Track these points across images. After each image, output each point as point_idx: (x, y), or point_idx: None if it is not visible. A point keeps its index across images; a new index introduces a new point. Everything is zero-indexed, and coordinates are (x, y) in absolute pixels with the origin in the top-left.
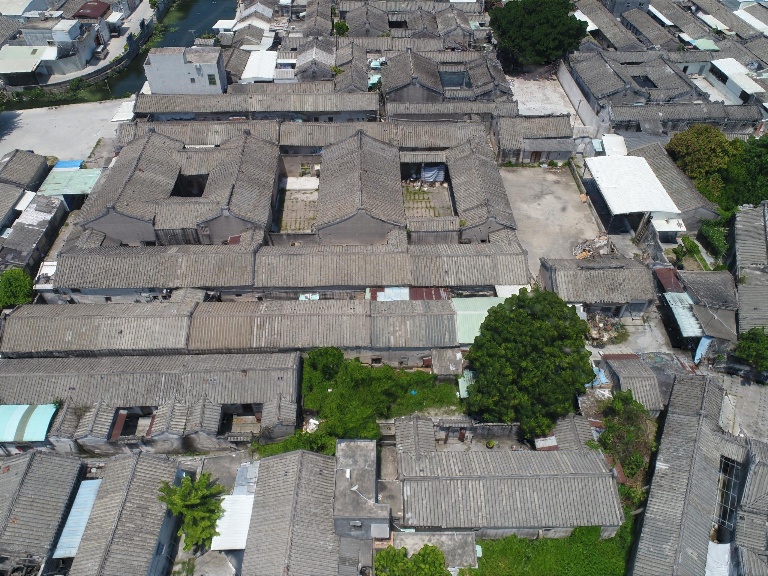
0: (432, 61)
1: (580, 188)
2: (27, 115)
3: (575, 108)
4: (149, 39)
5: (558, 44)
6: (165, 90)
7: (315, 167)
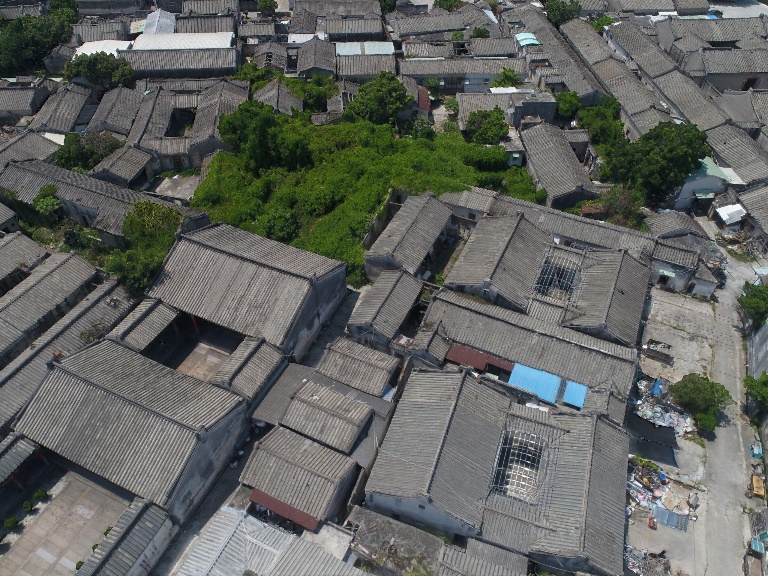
0: None
1: None
2: (760, 6)
3: None
4: None
5: None
6: None
7: None
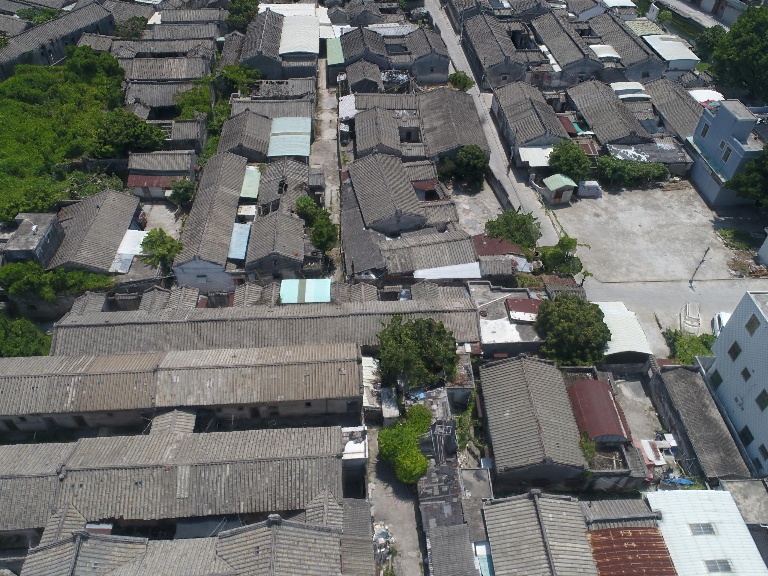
0: None
1: None
2: None
3: None
4: None
5: None
6: None
7: None
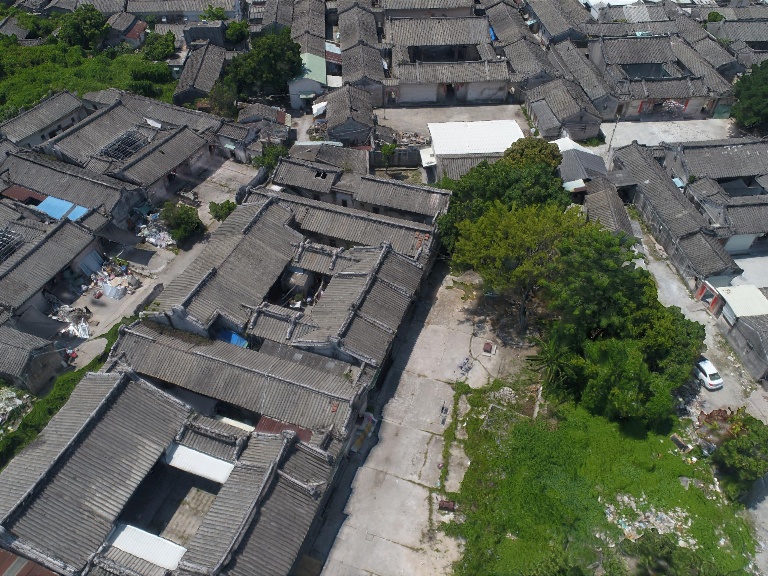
0: (673, 57)
1: None
2: None
3: None
4: None
5: None
6: None
7: None
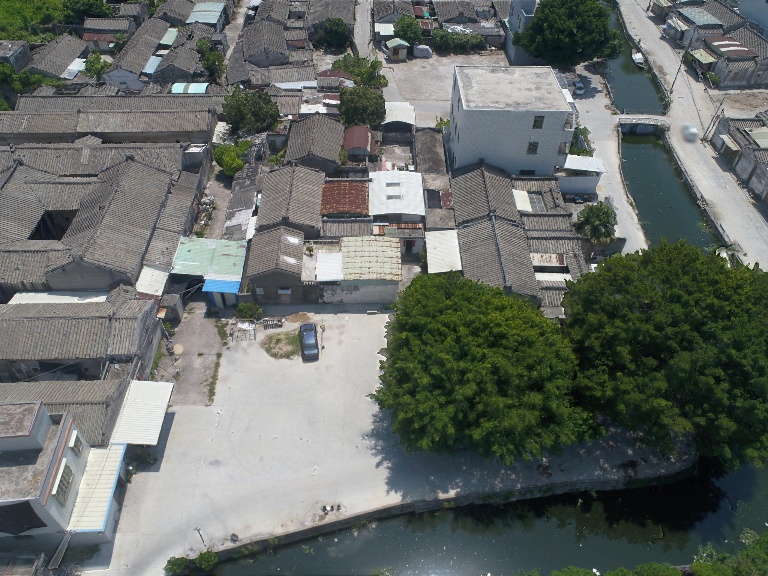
0: None
1: None
2: (373, 481)
3: None
4: None
5: None
6: None
7: None
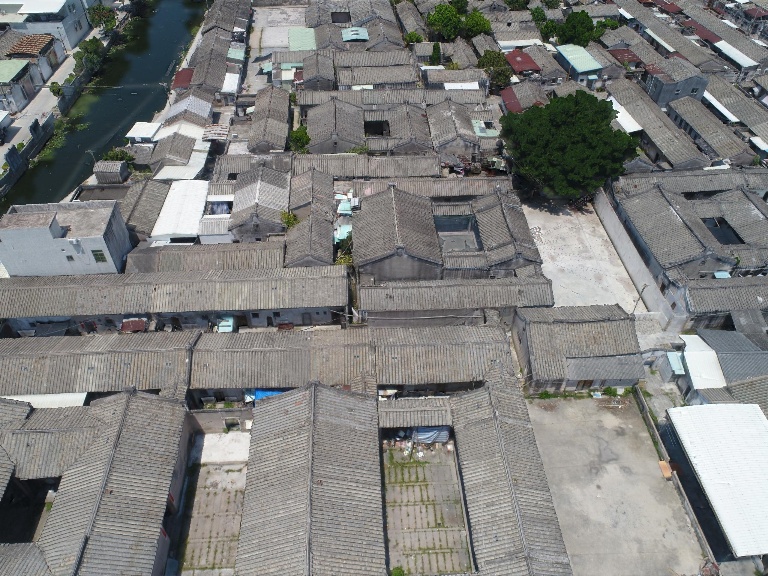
0: (424, 200)
1: (658, 447)
2: None
3: (626, 267)
4: (46, 144)
5: (598, 169)
6: (30, 271)
7: (246, 423)
